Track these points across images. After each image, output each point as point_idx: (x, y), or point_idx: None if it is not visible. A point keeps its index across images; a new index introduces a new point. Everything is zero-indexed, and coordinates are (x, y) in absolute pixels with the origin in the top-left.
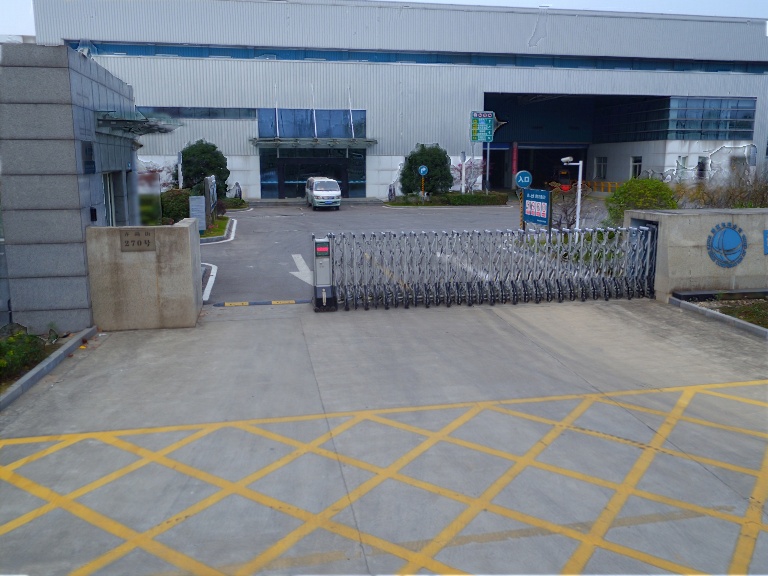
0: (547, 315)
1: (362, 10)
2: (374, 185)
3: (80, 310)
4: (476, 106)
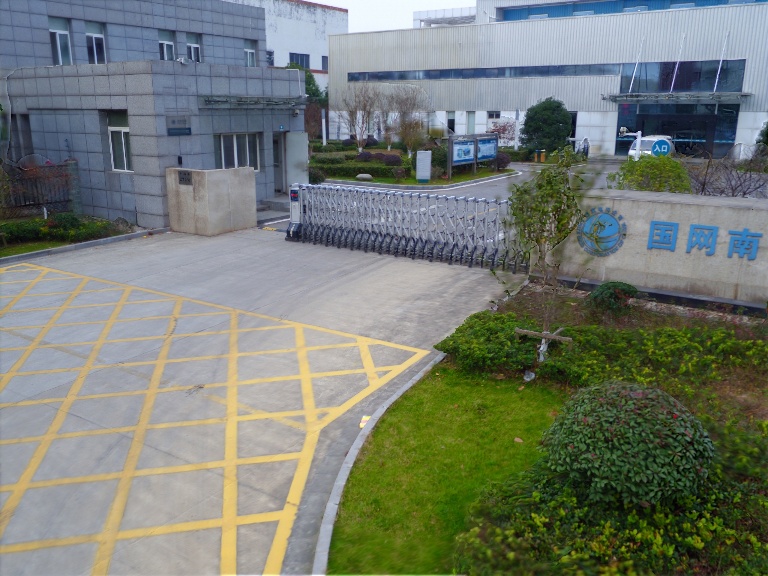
0: (403, 270)
1: None
2: None
3: (160, 216)
4: None
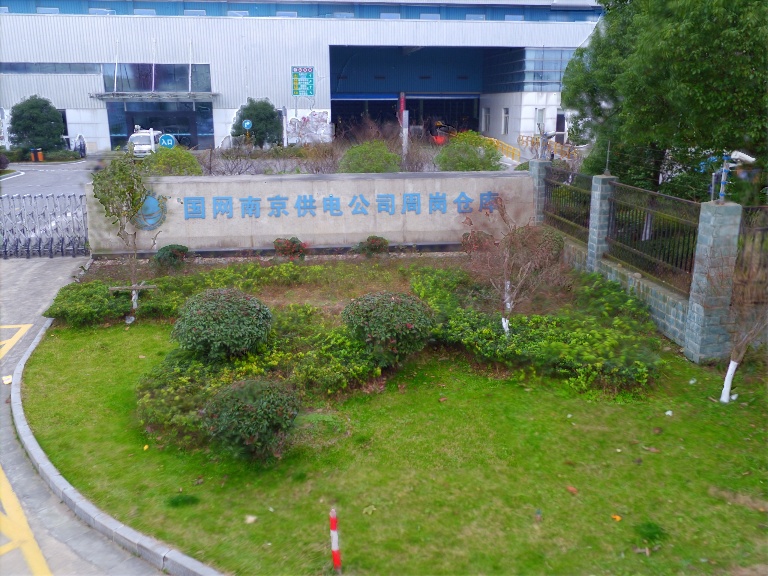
0: None
1: None
2: (222, 138)
3: None
4: (321, 59)
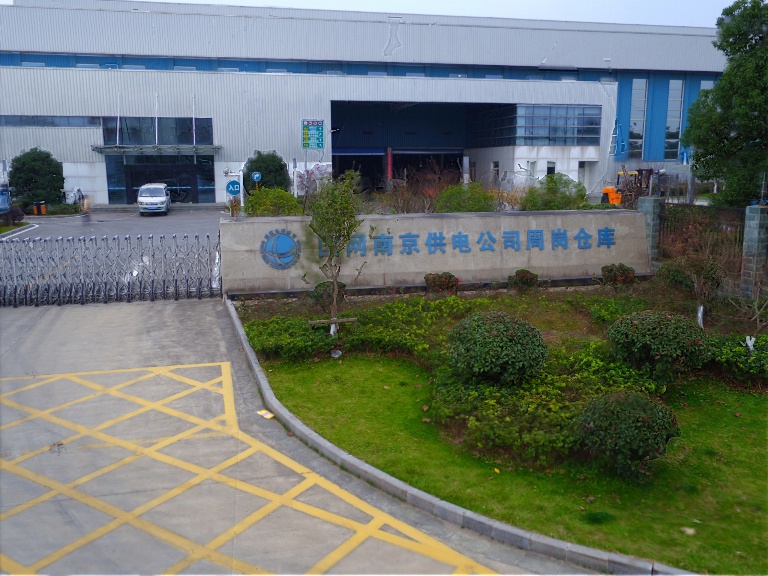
0: (89, 314)
1: (228, 19)
2: (223, 190)
3: None
4: (323, 114)
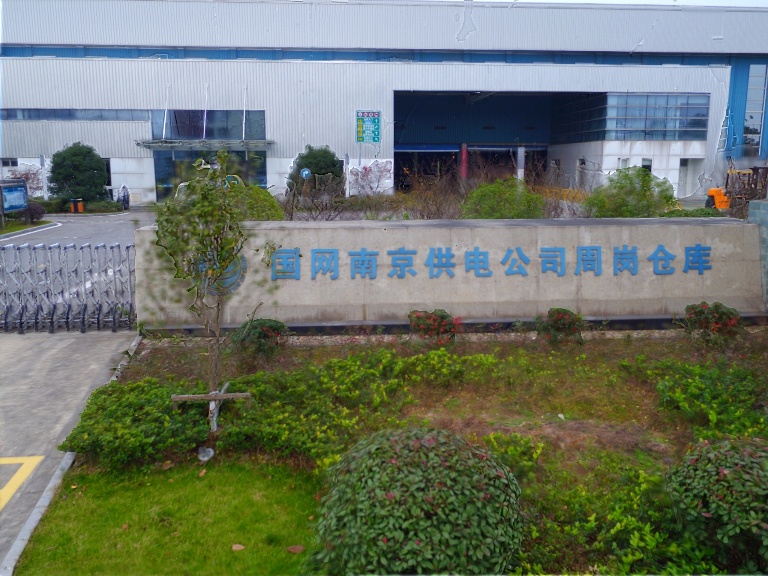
0: None
1: (293, 7)
2: (276, 189)
3: None
4: (385, 105)
